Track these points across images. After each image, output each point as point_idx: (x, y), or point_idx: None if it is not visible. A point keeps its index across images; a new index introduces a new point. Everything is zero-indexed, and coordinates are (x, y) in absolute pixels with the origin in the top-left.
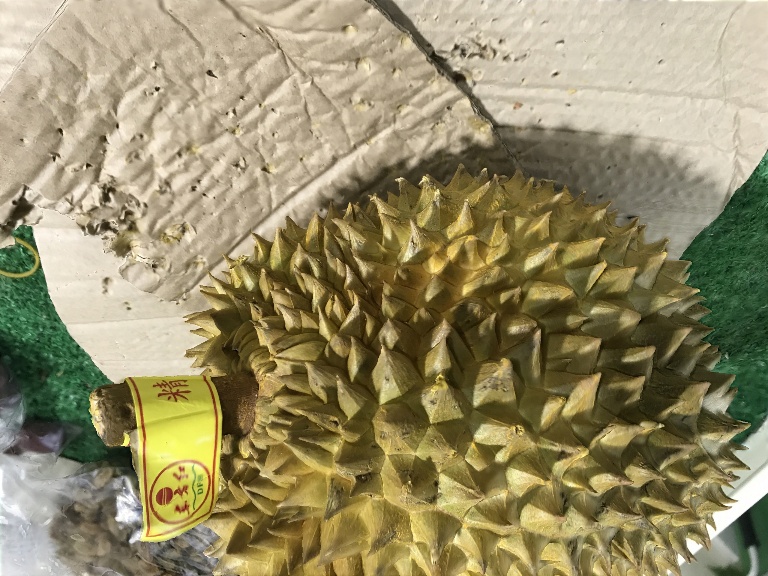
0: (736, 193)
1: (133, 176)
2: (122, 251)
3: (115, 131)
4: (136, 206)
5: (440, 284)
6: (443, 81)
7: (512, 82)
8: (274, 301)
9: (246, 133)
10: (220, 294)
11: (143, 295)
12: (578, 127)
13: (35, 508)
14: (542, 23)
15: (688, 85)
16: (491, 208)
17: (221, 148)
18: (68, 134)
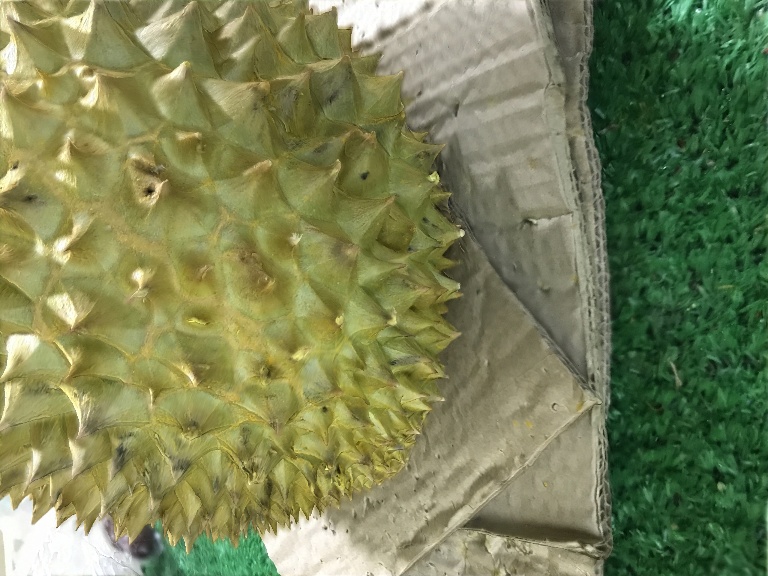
0: (657, 70)
1: None
2: None
3: None
4: None
5: None
6: None
7: (337, 7)
8: None
9: None
10: None
11: None
12: (388, 24)
13: (67, 566)
14: None
15: None
16: None
17: None
18: None
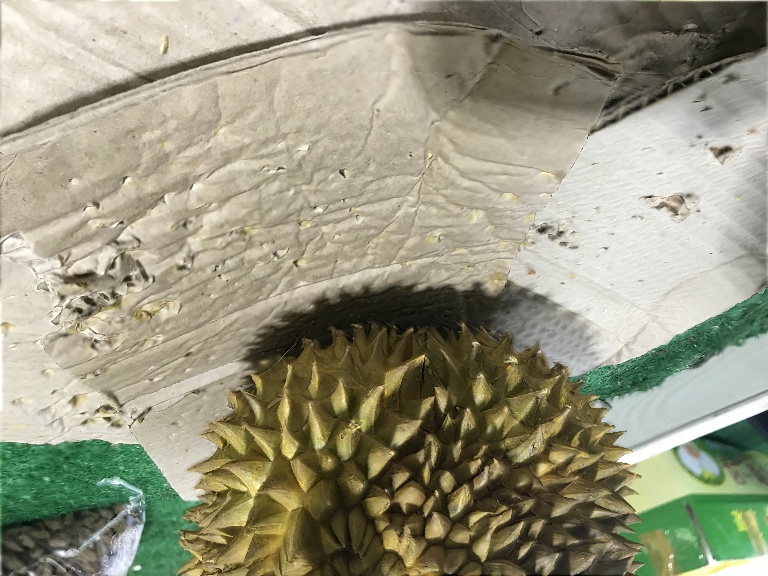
0: None
1: (164, 244)
2: None
3: (185, 191)
4: (143, 279)
5: (571, 506)
6: (512, 244)
7: (547, 258)
8: (405, 495)
9: (311, 227)
10: (305, 458)
11: None
12: (554, 299)
13: None
14: (610, 234)
15: (639, 299)
16: (561, 405)
17: (277, 235)
18: (132, 184)
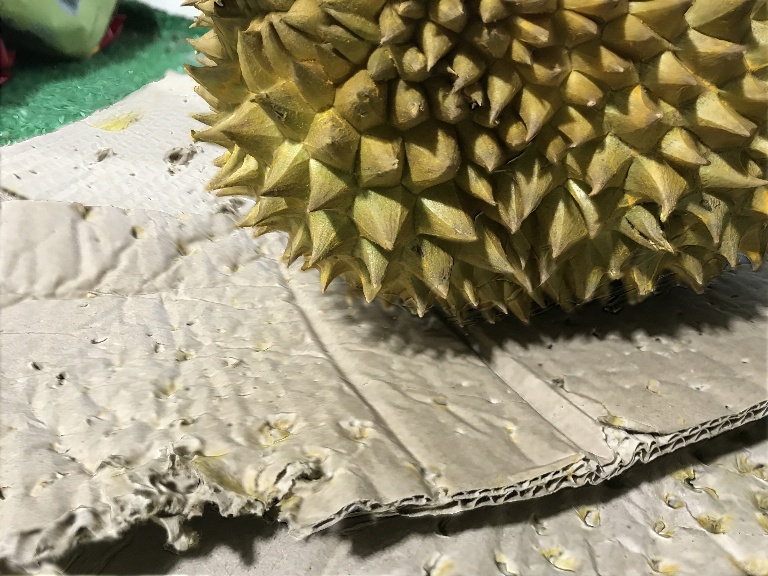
0: None
1: None
2: None
3: None
4: None
5: None
6: None
7: None
8: None
9: (198, 351)
10: None
11: None
12: None
13: None
14: None
15: None
16: None
17: None
18: None
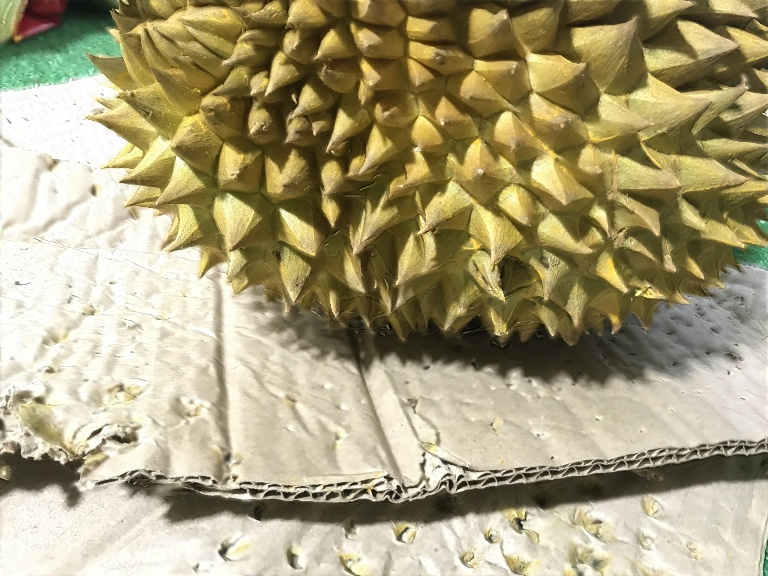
0: None
1: None
2: None
3: None
4: None
5: None
6: None
7: None
8: None
9: (107, 309)
10: None
11: None
12: None
13: None
14: None
15: None
16: None
17: (93, 325)
18: None
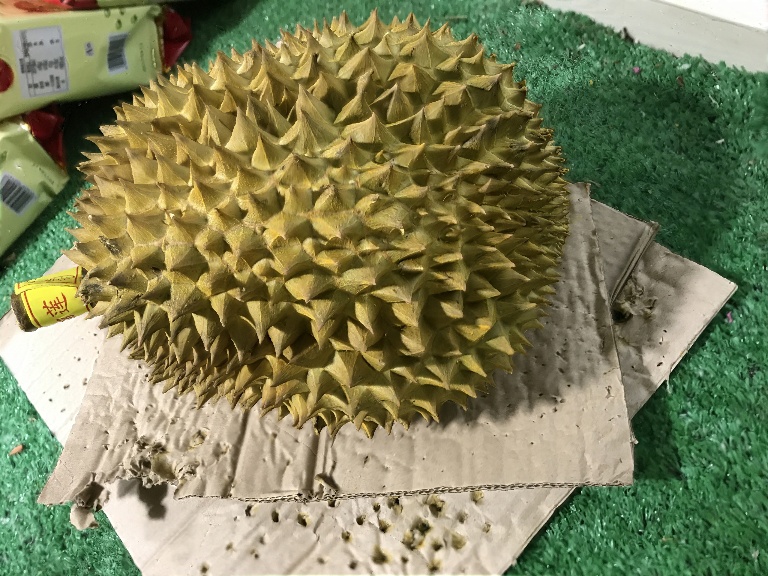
0: None
1: (155, 427)
2: (166, 476)
3: None
4: None
5: None
6: None
7: None
8: None
9: None
10: None
11: (237, 559)
12: None
13: None
14: None
15: None
16: None
17: None
18: (111, 431)
